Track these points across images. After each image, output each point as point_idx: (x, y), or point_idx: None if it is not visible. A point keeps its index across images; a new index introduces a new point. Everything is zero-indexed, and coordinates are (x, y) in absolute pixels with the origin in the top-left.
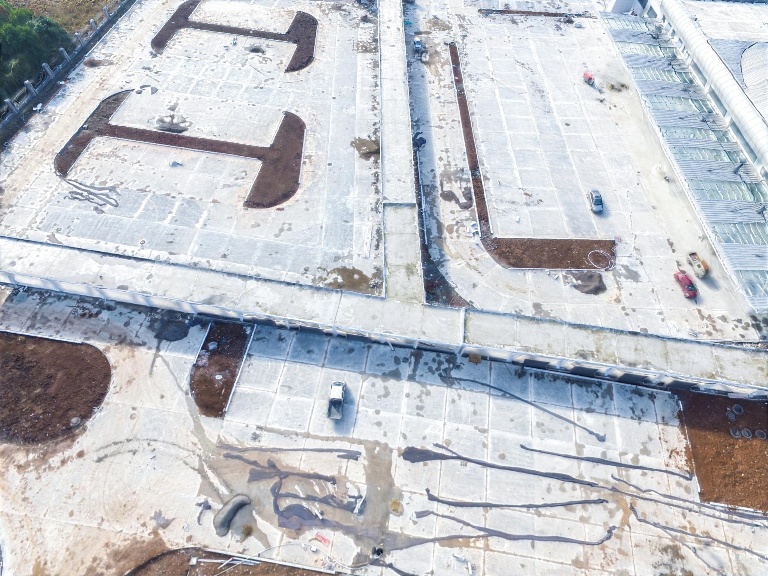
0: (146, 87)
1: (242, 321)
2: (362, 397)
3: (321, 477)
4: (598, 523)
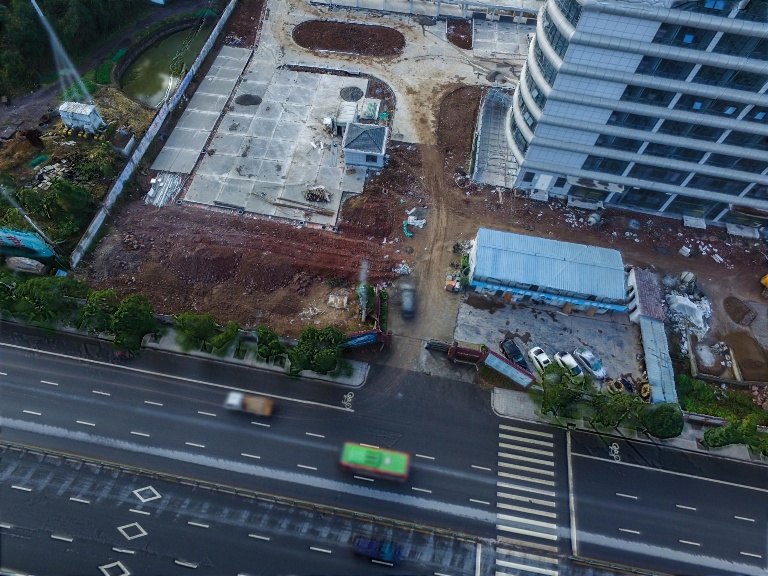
0: None
1: (465, 18)
2: None
3: None
4: None
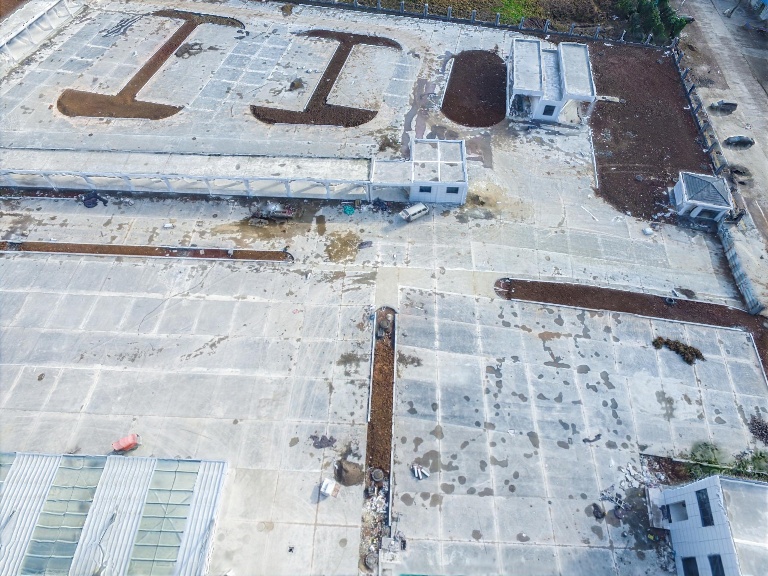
0: (246, 34)
1: None
2: None
3: None
4: None
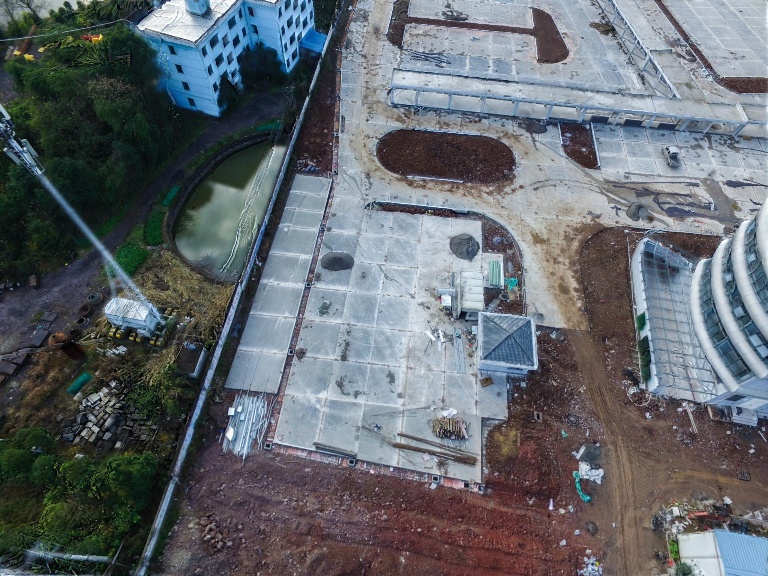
0: None
1: (581, 121)
2: (684, 157)
3: (681, 195)
4: None
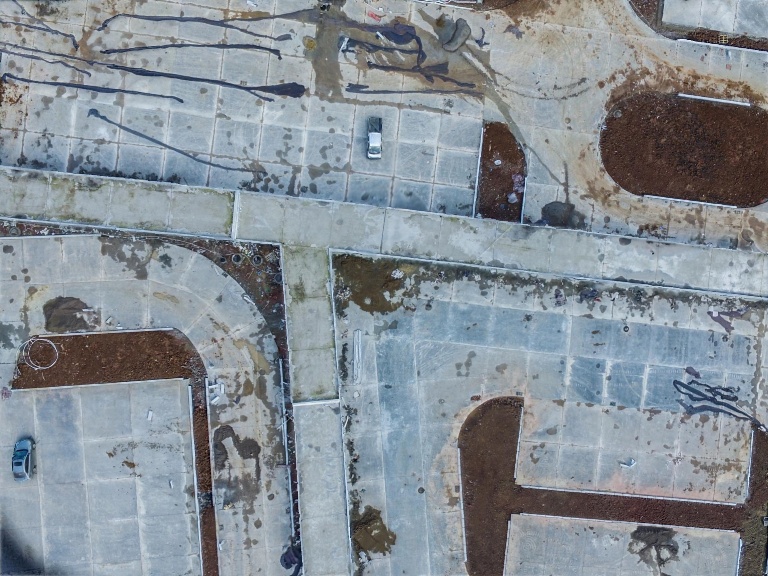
0: None
1: None
2: (349, 146)
3: (382, 68)
4: (115, 32)
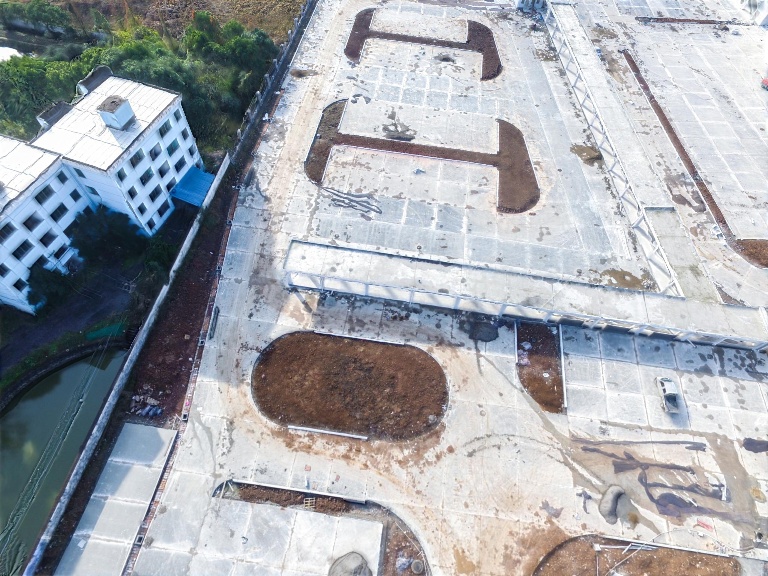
0: (358, 96)
1: (546, 322)
2: (685, 392)
3: (679, 467)
4: None
